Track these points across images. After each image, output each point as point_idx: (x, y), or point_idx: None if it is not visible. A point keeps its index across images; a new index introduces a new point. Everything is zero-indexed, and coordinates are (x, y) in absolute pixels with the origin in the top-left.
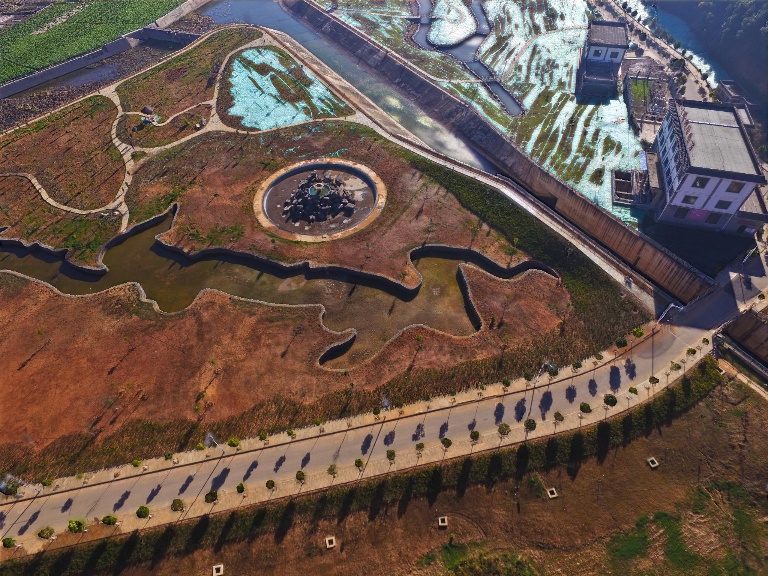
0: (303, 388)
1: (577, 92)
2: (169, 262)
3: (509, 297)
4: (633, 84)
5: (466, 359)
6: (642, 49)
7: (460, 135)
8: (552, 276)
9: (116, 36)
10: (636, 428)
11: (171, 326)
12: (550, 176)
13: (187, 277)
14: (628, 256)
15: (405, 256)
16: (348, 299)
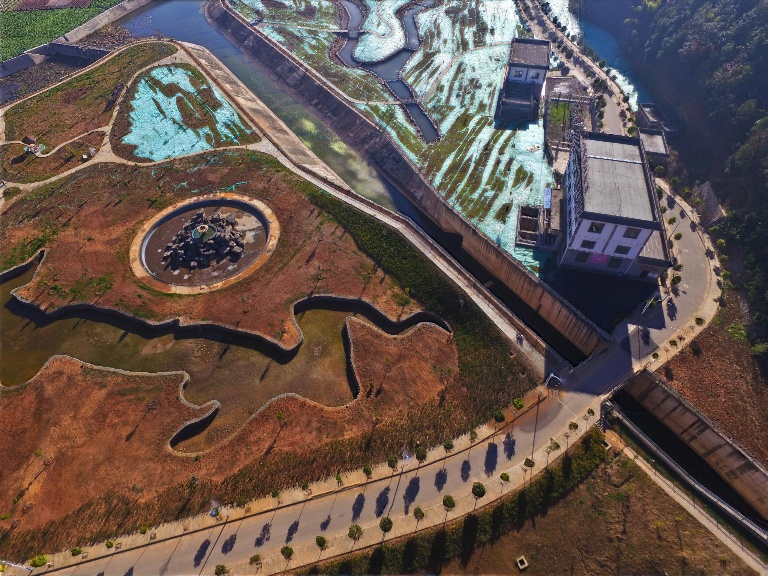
0: (143, 480)
1: (497, 115)
2: (23, 321)
3: (393, 357)
4: (554, 107)
5: (332, 438)
6: (568, 67)
7: (373, 163)
8: (444, 330)
9: (18, 52)
10: (507, 521)
11: (6, 404)
12: (454, 213)
13: (40, 340)
14: (531, 302)
15: (288, 309)
16: (218, 363)
